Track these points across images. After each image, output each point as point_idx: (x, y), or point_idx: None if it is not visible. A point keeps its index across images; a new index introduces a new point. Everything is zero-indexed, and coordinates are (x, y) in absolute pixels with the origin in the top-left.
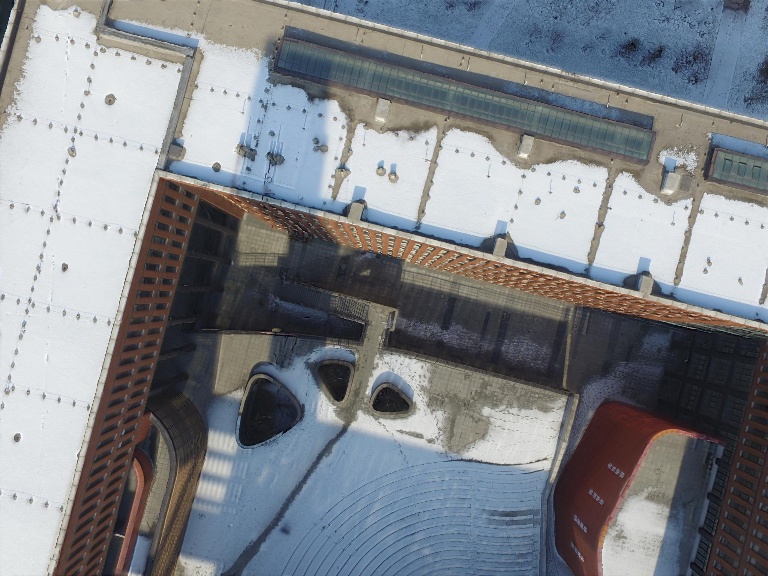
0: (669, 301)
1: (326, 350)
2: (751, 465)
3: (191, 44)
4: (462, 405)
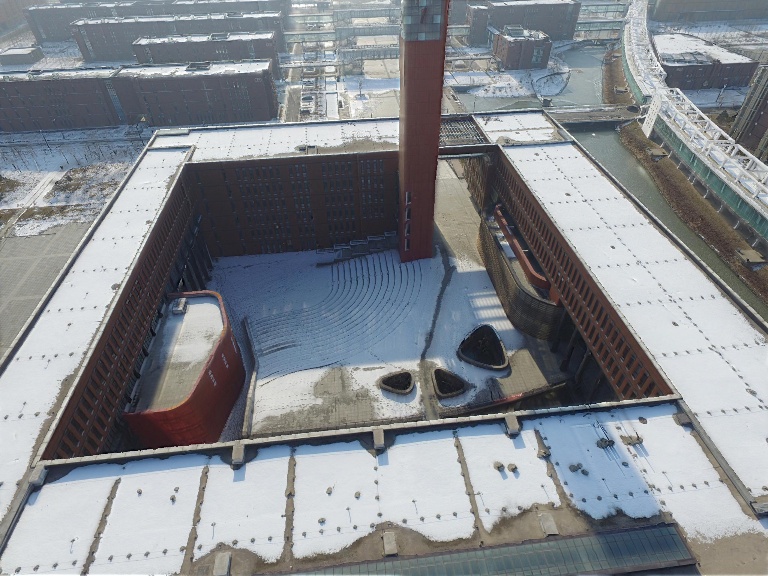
0: (215, 446)
1: (466, 401)
2: (114, 389)
3: (767, 521)
4: (341, 399)
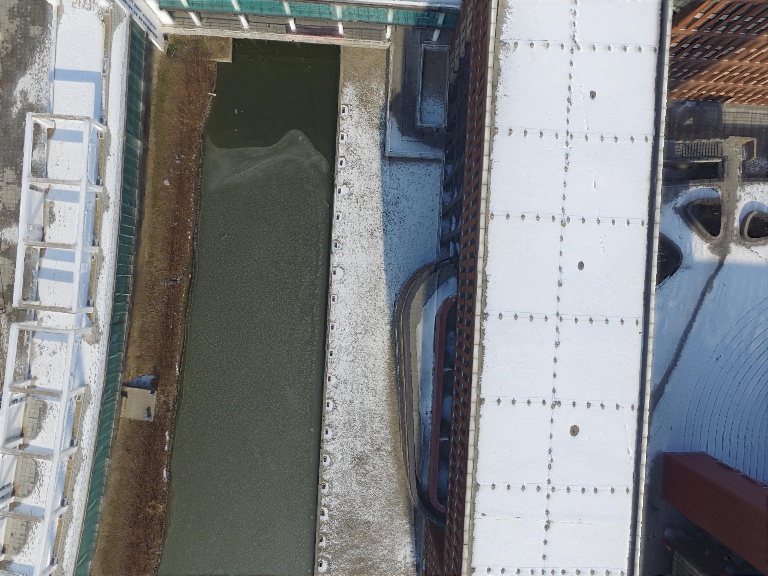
0: None
1: (691, 192)
2: None
3: None
4: None
